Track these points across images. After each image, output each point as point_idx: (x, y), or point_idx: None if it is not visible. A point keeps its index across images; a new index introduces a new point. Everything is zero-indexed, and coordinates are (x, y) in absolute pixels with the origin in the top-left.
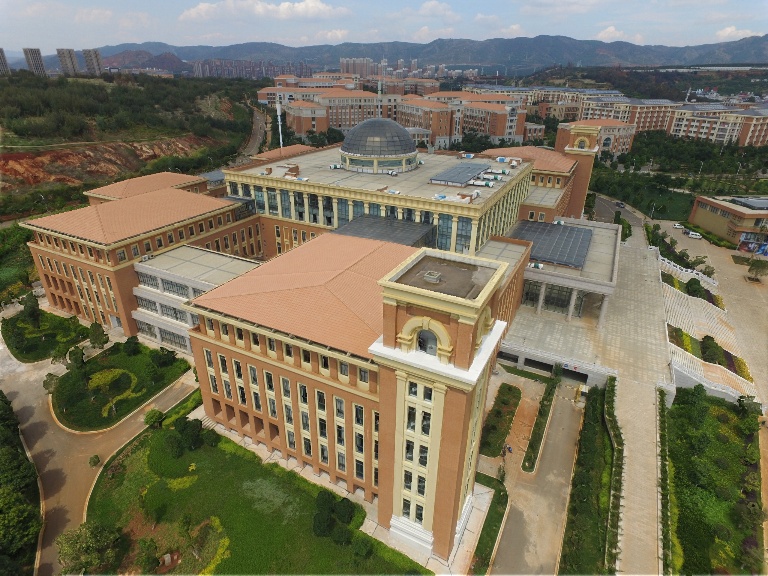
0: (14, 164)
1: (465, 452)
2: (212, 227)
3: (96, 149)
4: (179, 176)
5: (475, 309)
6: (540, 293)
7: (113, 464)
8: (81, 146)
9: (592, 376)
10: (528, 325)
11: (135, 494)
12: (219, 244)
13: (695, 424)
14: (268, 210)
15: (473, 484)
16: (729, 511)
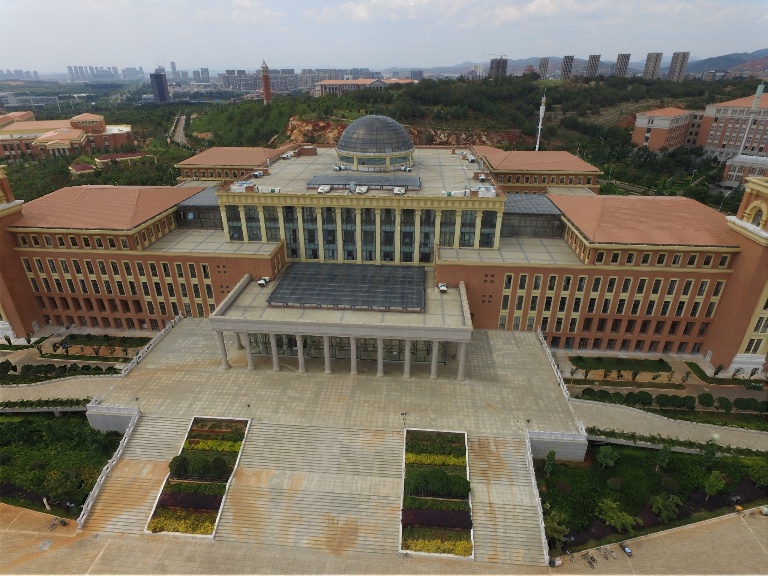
0: None
1: None
2: None
3: None
4: None
5: None
6: None
7: None
8: None
9: None
10: None
11: None
12: None
13: (66, 449)
14: None
15: (20, 326)
16: None
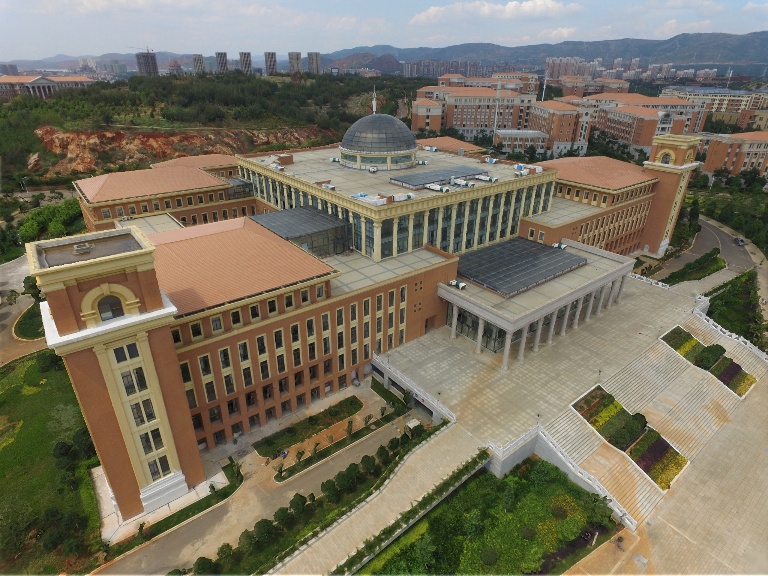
0: (152, 141)
1: (117, 421)
2: (202, 202)
3: (219, 134)
4: (226, 158)
5: (40, 277)
6: (453, 315)
7: (11, 364)
8: (208, 130)
9: (435, 414)
10: (427, 346)
11: (2, 389)
12: (207, 218)
13: (512, 505)
14: (260, 194)
15: (198, 468)
16: None
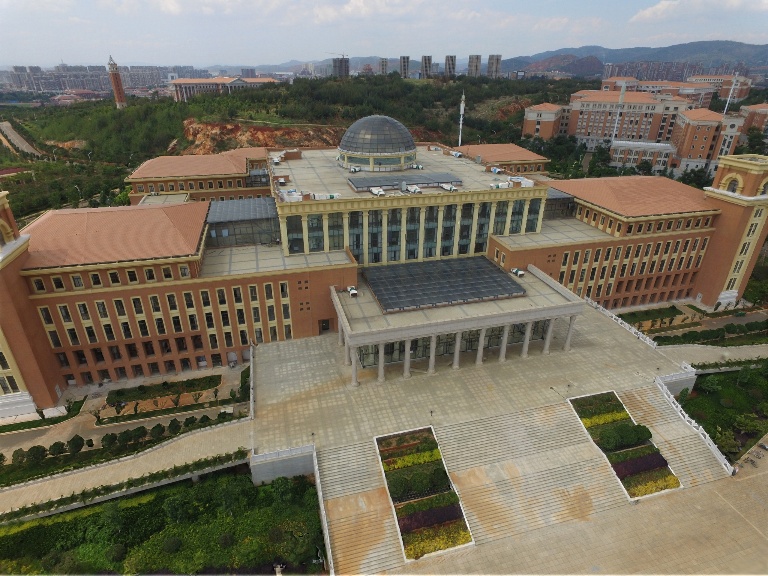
0: (260, 134)
1: None
2: (222, 187)
3: (320, 130)
4: None
5: None
6: (338, 321)
7: None
8: (311, 127)
9: None
10: (308, 346)
11: None
12: None
13: (241, 511)
14: None
15: (45, 394)
16: (96, 567)
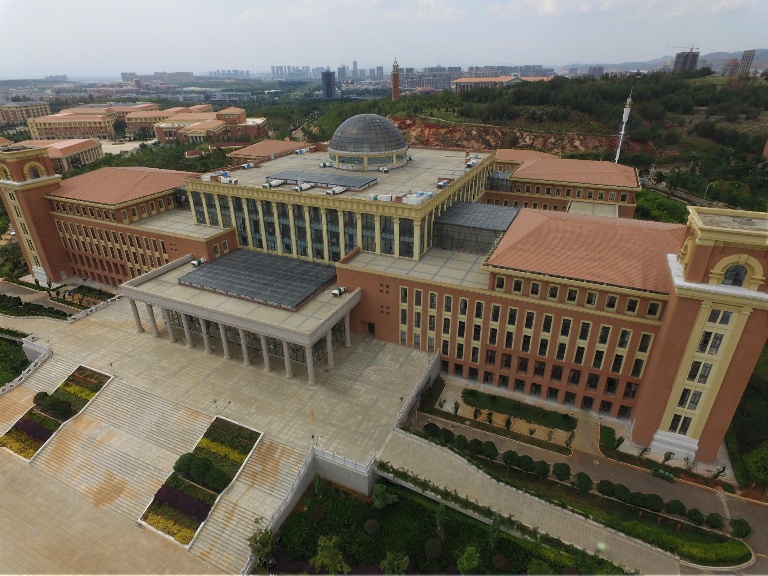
0: (427, 130)
1: None
2: None
3: (486, 131)
4: None
5: None
6: None
7: None
8: (478, 127)
9: None
10: None
11: None
12: None
13: (4, 369)
14: None
15: (50, 273)
16: None
